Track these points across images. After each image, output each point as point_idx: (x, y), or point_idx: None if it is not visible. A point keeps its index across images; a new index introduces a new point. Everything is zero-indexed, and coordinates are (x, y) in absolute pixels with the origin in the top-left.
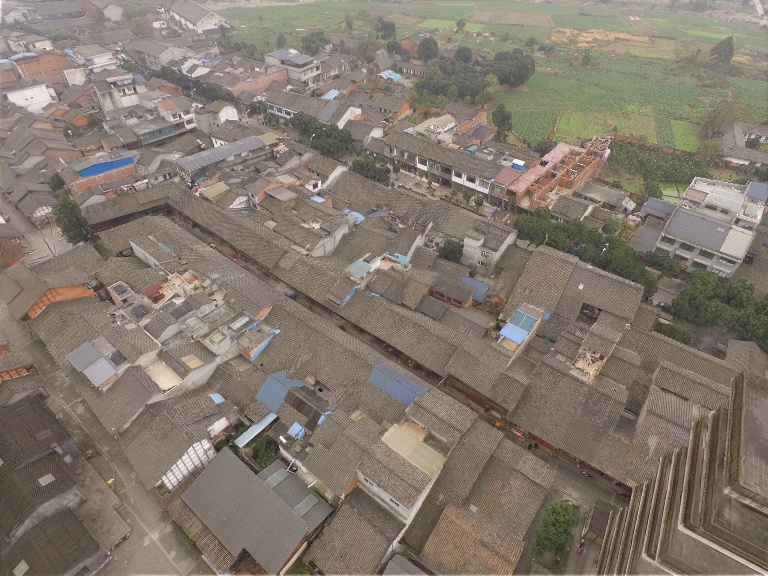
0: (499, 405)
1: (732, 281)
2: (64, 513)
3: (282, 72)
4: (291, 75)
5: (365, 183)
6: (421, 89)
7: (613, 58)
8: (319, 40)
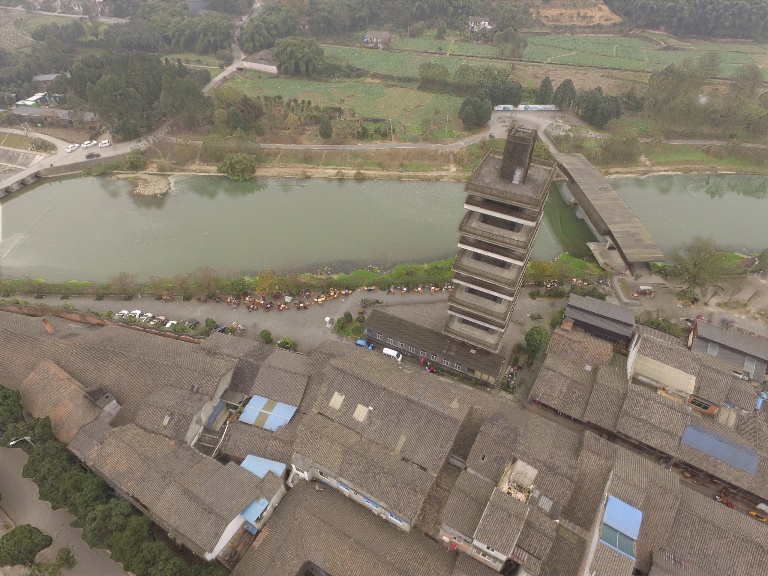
0: None
1: None
2: None
3: None
4: None
5: None
6: None
7: None
8: None
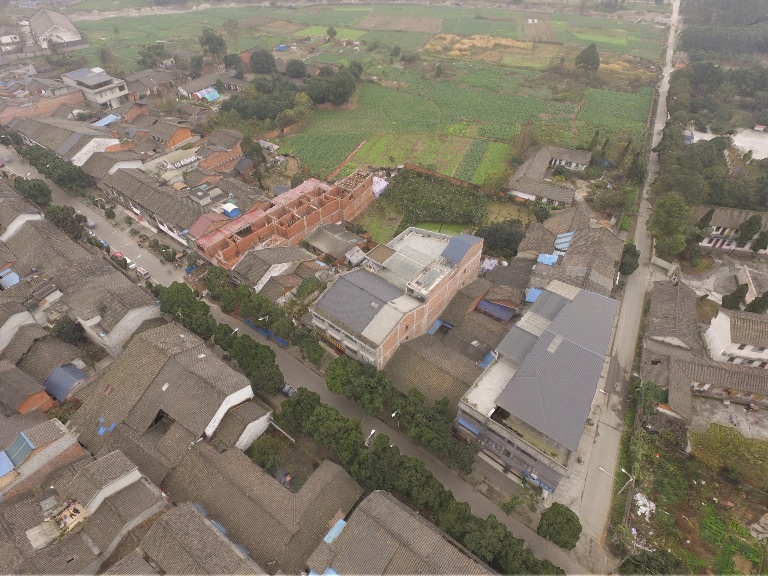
0: None
1: (388, 369)
2: None
3: (75, 94)
4: (88, 97)
5: (40, 236)
6: (223, 111)
7: (475, 68)
8: (156, 54)
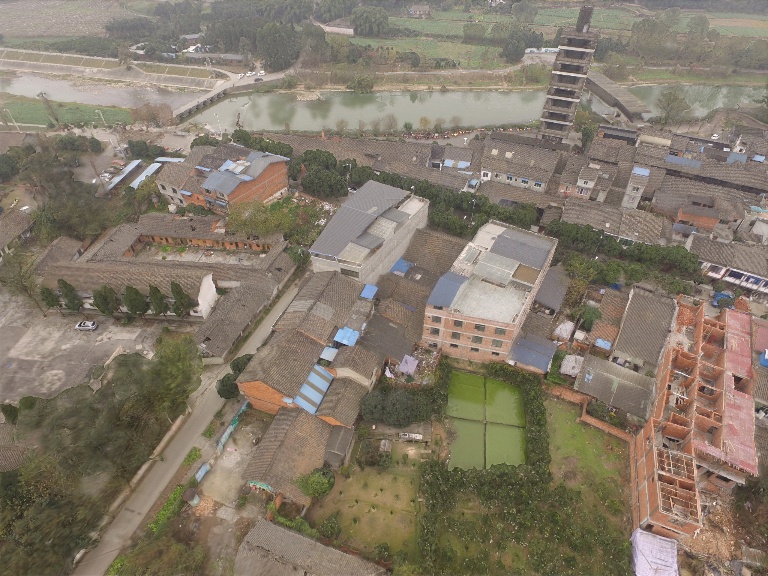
0: None
1: None
2: (760, 136)
3: None
4: None
5: None
6: None
7: None
8: None
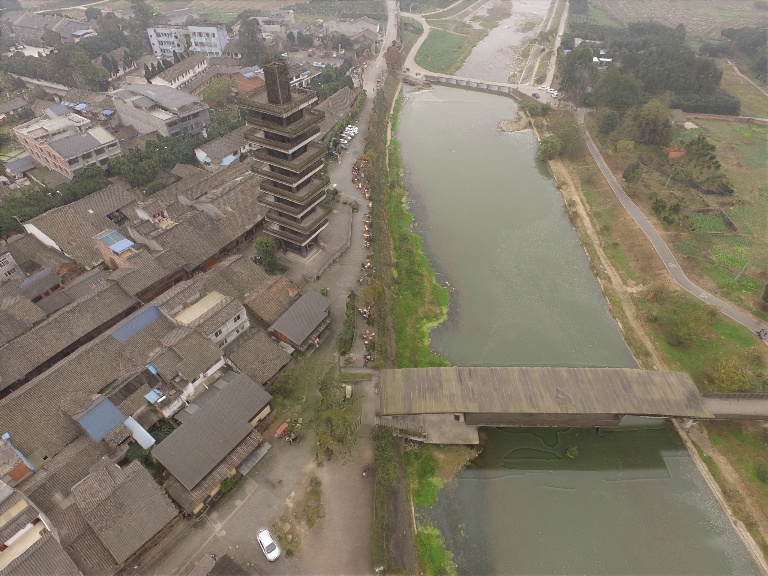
0: (177, 272)
1: None
2: None
3: None
4: None
5: None
6: None
7: None
8: None
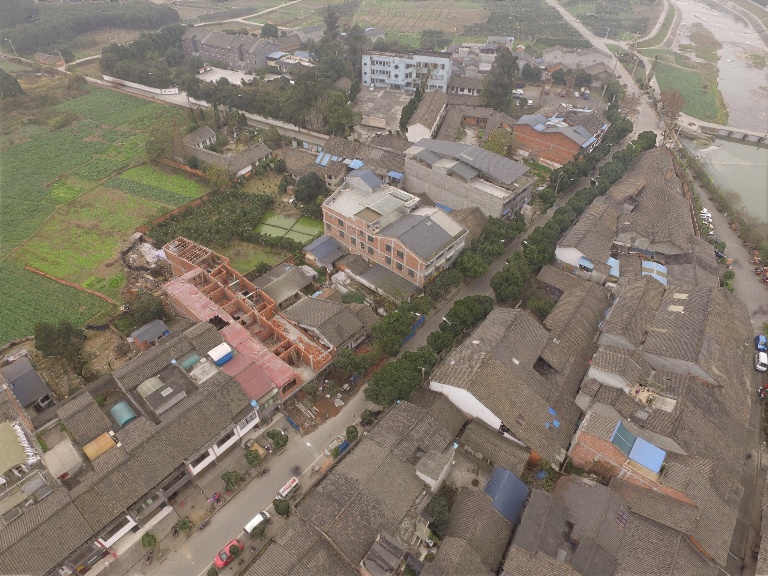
0: None
1: None
2: None
3: None
4: None
5: None
6: None
7: None
8: None
